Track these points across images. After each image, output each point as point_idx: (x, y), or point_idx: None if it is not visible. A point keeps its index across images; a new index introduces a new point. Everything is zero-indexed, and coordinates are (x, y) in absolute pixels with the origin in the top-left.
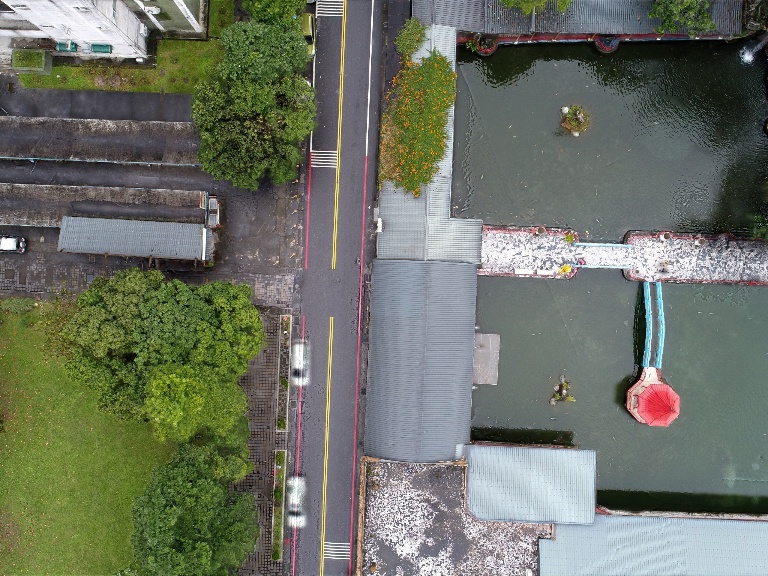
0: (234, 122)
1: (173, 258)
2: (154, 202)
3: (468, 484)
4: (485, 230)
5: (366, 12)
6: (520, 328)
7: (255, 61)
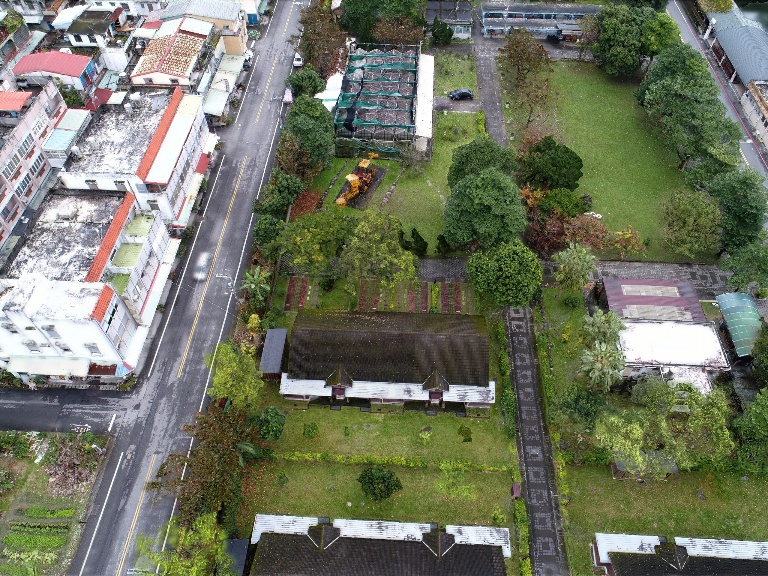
0: None
1: None
2: None
3: None
4: None
5: None
6: None
7: None
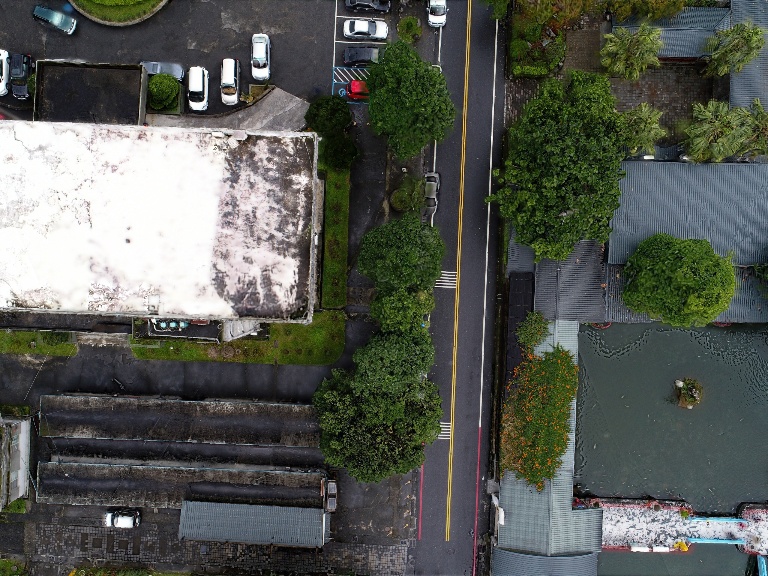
0: (364, 434)
1: (294, 546)
2: (272, 483)
3: None
4: None
5: (479, 284)
6: None
7: (390, 385)
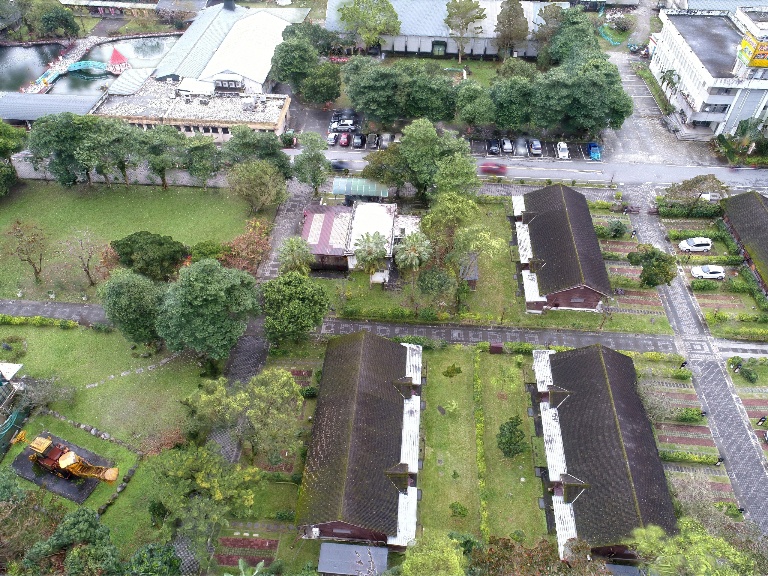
0: None
1: None
2: None
3: None
4: None
5: None
6: None
7: None
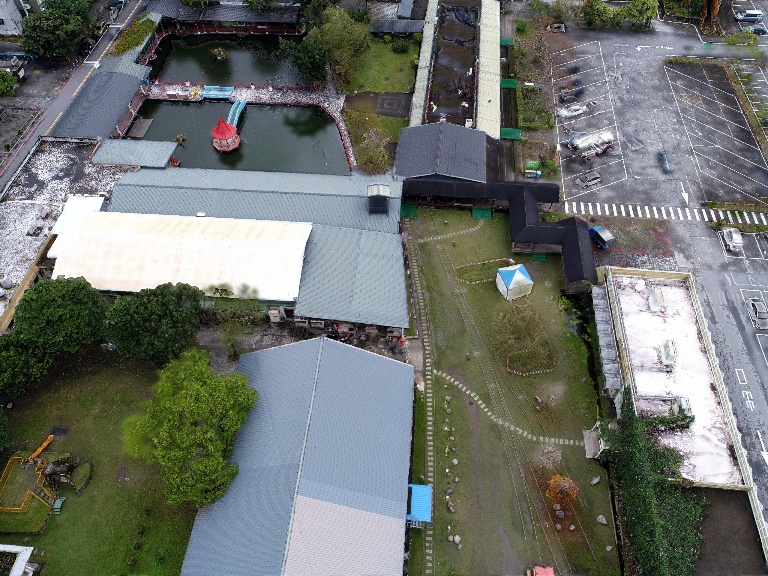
0: None
1: None
2: None
3: (97, 151)
4: (160, 84)
5: None
6: (167, 120)
7: None
